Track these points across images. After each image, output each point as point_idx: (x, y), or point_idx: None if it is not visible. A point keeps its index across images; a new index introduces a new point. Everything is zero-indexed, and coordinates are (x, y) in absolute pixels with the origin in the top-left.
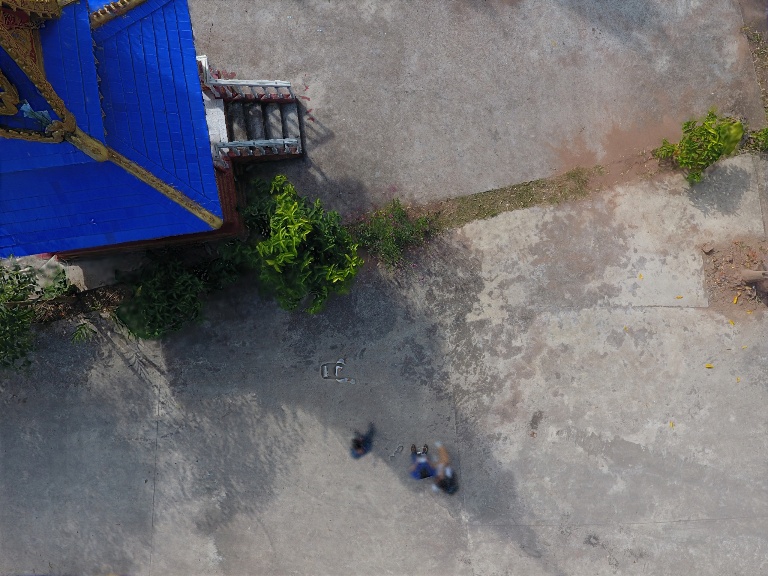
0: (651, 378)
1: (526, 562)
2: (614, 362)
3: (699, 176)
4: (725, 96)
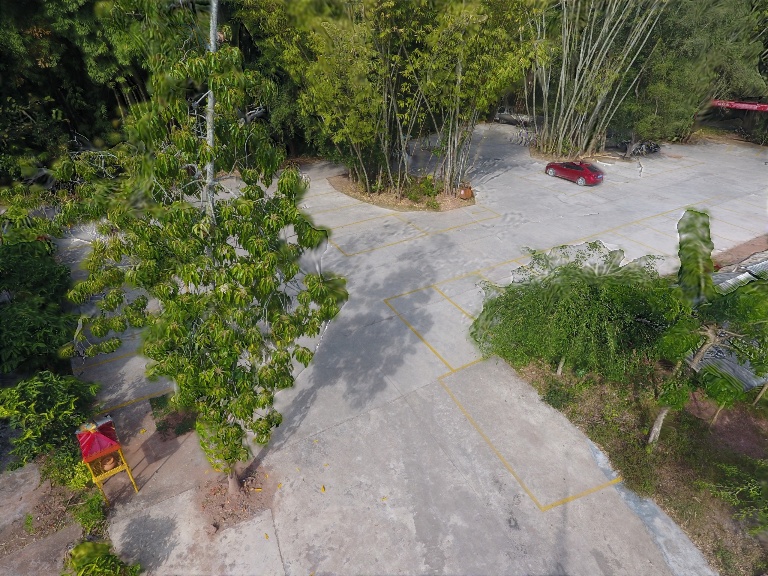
0: (351, 532)
1: (574, 575)
2: (349, 572)
3: (134, 567)
4: (35, 575)
